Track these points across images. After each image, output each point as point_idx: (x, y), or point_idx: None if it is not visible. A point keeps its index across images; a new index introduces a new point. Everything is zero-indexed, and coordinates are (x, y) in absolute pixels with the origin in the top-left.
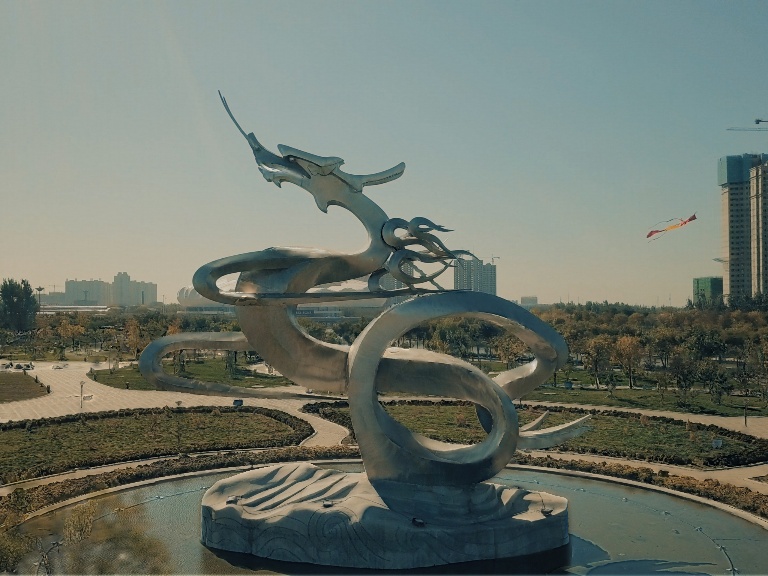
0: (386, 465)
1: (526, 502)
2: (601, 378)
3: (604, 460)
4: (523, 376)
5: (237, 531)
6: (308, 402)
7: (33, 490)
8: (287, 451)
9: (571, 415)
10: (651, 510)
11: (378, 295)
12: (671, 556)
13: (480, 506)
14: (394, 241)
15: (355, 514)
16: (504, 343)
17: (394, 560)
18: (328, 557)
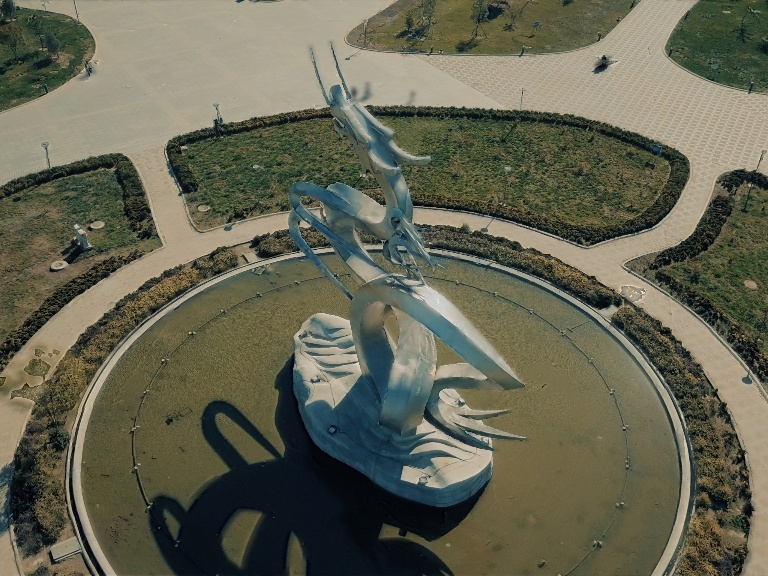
0: None
1: (430, 462)
2: None
3: None
4: (476, 377)
5: None
6: (767, 159)
7: None
8: (535, 260)
9: None
10: (601, 531)
11: (372, 264)
12: (471, 575)
13: (395, 443)
14: None
15: (310, 399)
16: None
17: None
18: None
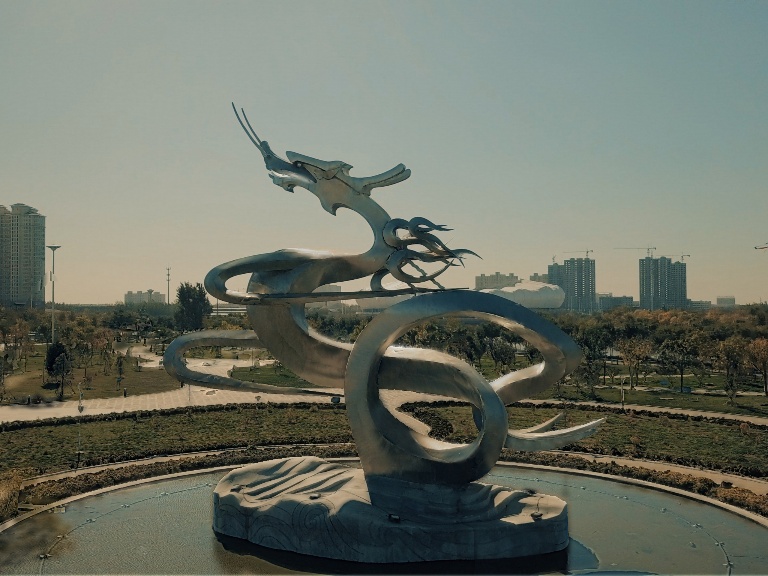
0: (381, 461)
1: (521, 505)
2: (738, 383)
3: (674, 469)
4: (529, 377)
5: (236, 518)
6: (411, 401)
7: (100, 473)
8: (350, 447)
9: (672, 421)
10: (684, 522)
11: (375, 295)
12: (667, 569)
13: (469, 506)
14: (394, 241)
15: (334, 507)
16: (626, 345)
17: (368, 554)
18: (308, 547)
